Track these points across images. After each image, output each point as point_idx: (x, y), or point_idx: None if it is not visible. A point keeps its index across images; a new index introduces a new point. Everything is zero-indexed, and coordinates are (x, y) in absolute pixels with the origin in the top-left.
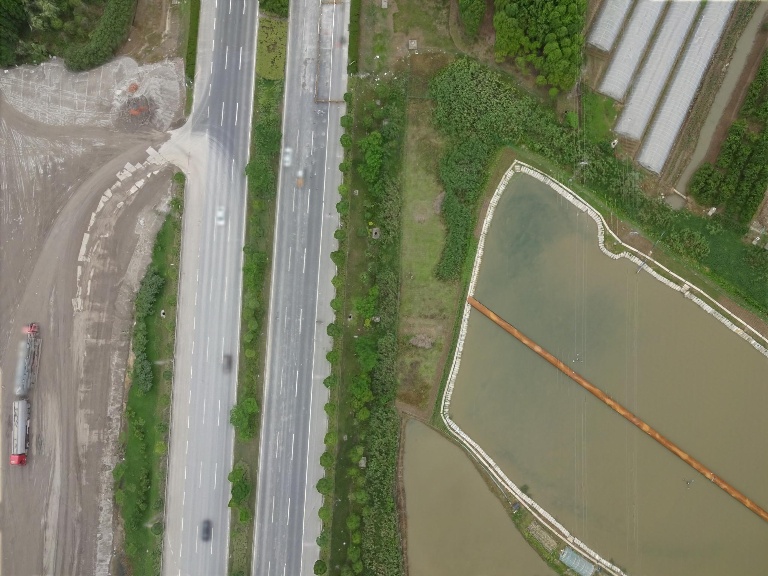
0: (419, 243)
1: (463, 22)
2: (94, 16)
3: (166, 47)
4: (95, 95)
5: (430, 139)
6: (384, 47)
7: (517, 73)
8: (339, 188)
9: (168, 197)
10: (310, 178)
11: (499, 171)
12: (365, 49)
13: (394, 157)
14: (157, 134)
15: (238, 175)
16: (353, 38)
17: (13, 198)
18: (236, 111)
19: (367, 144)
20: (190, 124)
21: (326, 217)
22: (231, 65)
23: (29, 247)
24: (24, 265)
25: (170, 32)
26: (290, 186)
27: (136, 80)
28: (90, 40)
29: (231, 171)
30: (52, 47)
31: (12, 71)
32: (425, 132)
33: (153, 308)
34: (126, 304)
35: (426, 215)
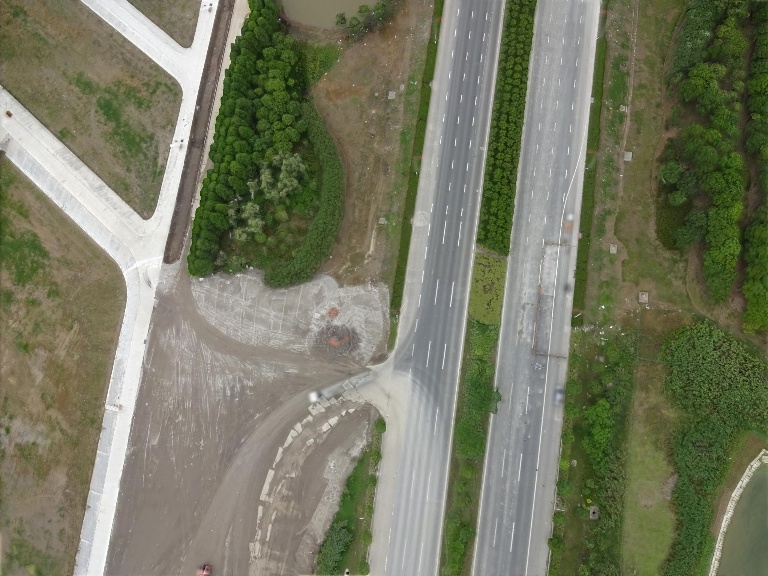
0: (644, 531)
1: (708, 285)
2: (296, 229)
3: (369, 269)
4: (292, 316)
5: (661, 410)
6: (610, 297)
7: (764, 344)
8: (561, 464)
9: (363, 441)
10: (523, 441)
11: (743, 459)
12: (590, 298)
13: (618, 425)
14: (355, 368)
15: (442, 426)
16: (580, 288)
17: (196, 419)
18: (444, 353)
19: (595, 416)
20: (392, 361)
21: (539, 489)
22: (441, 301)
23: (208, 476)
24: (201, 496)
25: (374, 253)
26: (500, 447)
27: (337, 304)
28: (293, 257)
29: (434, 420)
30: (250, 256)
31: (207, 279)
32: (655, 400)
33: (337, 567)
34: (307, 557)
35: (653, 499)
